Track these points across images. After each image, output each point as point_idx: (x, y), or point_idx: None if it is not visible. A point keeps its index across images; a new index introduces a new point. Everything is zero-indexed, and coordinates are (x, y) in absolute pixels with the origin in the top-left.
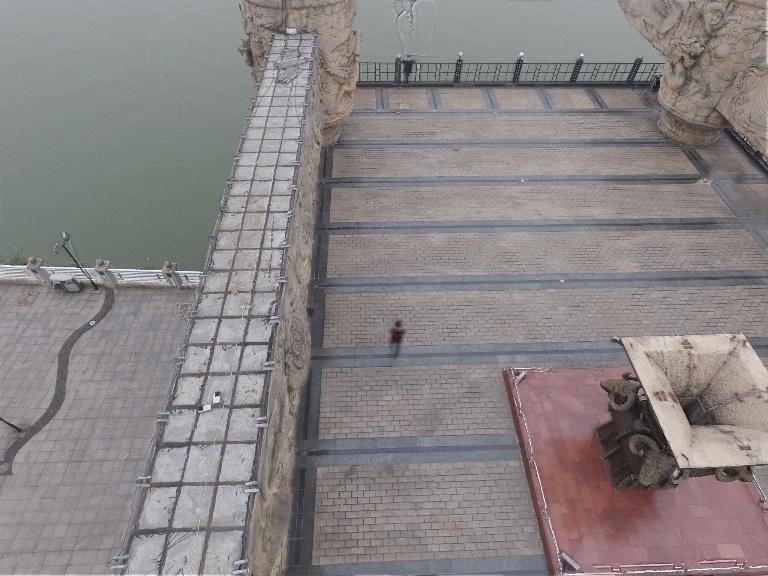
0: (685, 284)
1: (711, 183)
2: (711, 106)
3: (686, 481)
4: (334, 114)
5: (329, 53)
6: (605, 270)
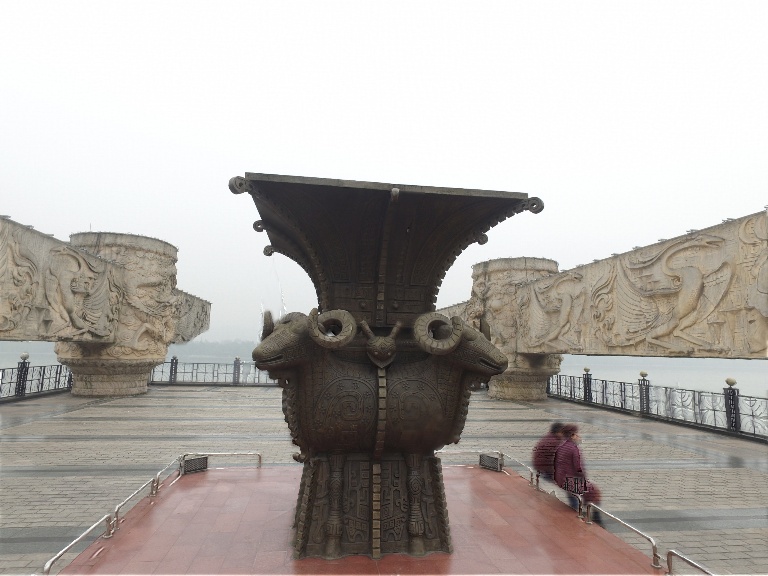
0: (509, 439)
1: (542, 410)
2: (512, 351)
3: (476, 546)
4: (128, 348)
5: (133, 287)
6: None
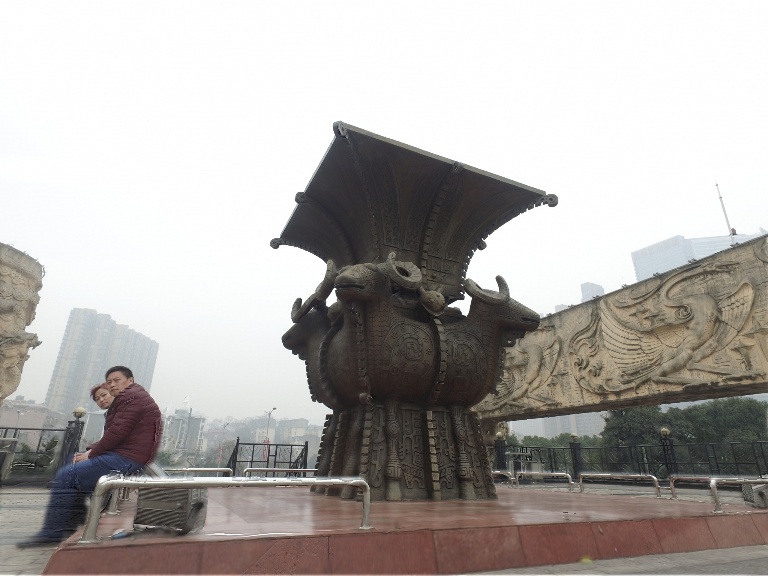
0: None
1: None
2: None
3: None
4: None
5: None
6: None
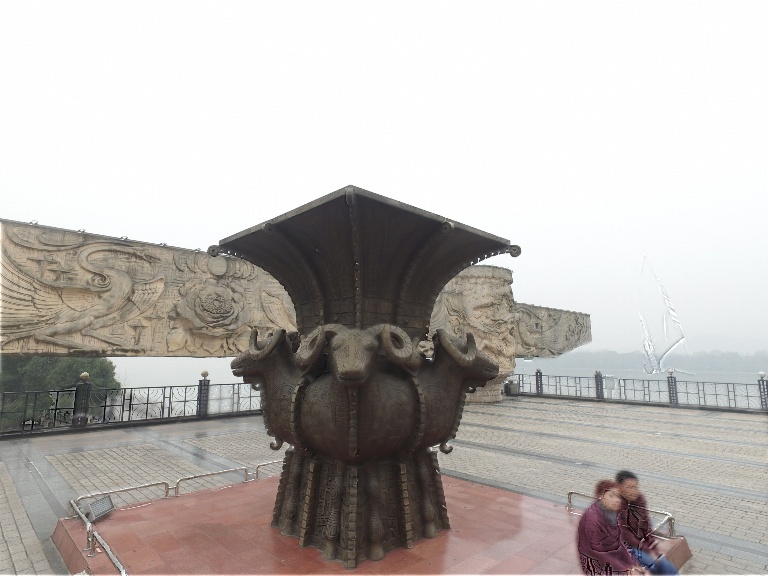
0: None
1: None
2: None
3: (382, 575)
4: None
5: (470, 309)
6: (677, 475)
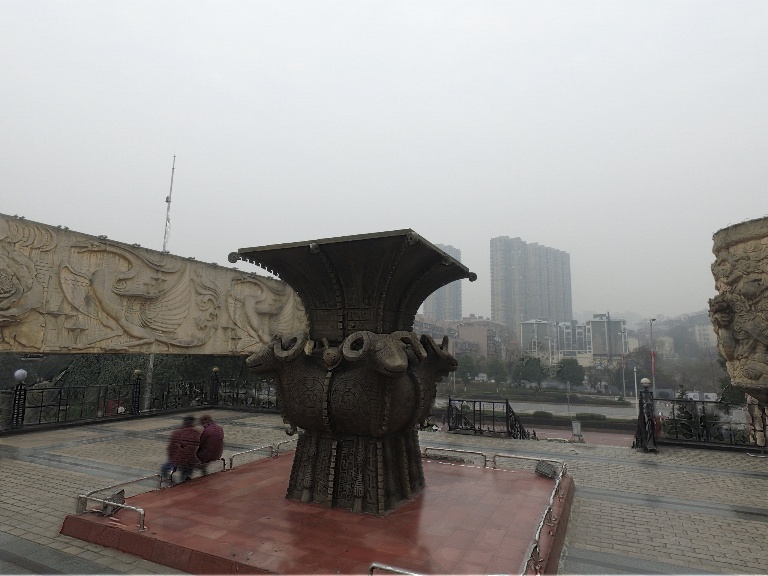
0: None
1: None
2: None
3: None
4: None
5: None
6: None
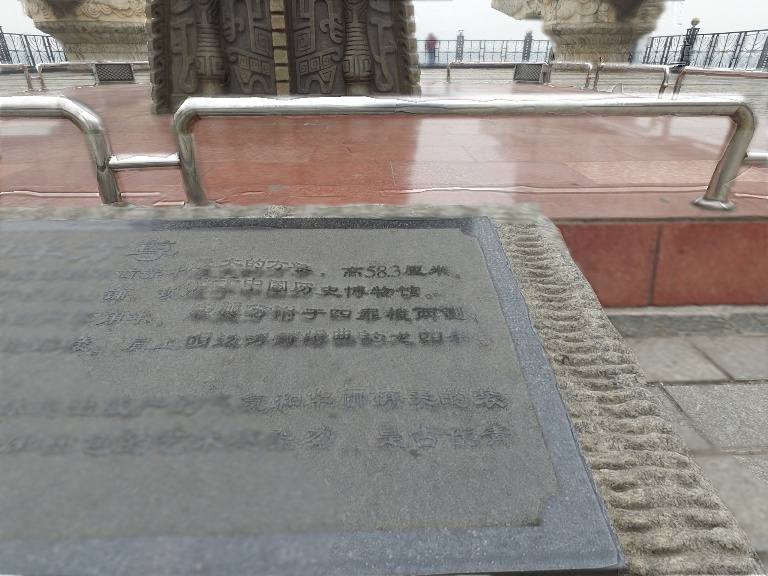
0: None
1: (619, 75)
2: None
3: None
4: (105, 6)
5: None
6: None
